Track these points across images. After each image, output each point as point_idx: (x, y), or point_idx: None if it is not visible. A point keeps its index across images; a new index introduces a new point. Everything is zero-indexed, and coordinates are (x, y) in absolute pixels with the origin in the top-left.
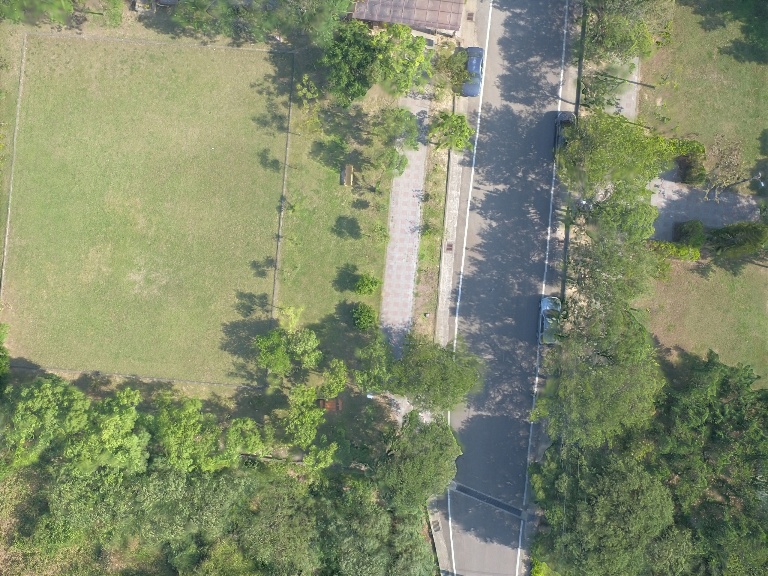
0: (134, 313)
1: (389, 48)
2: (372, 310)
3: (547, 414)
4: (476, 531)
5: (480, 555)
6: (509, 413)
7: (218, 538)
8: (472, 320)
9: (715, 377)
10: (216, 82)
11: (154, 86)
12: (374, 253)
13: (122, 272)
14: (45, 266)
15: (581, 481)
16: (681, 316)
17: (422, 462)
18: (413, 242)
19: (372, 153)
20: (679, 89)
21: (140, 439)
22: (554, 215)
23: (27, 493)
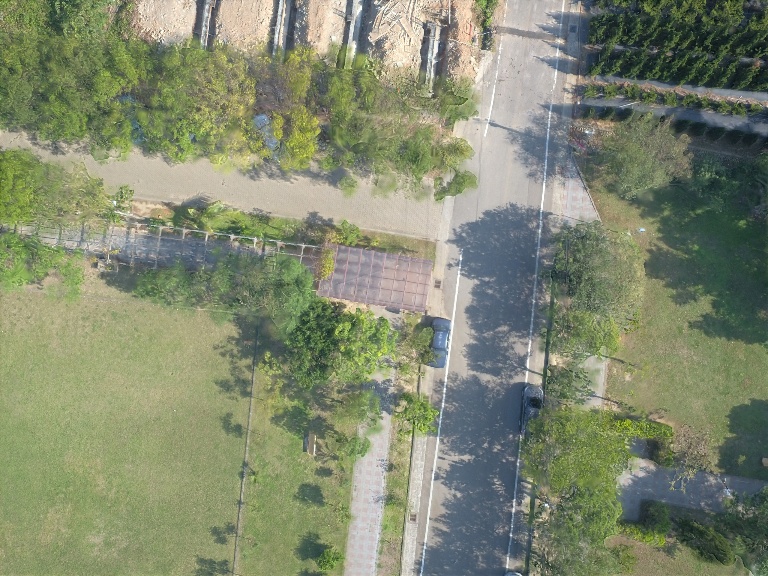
0: (93, 575)
1: (351, 341)
2: None
3: None
4: None
5: None
6: None
7: None
8: None
9: None
10: (179, 343)
11: (116, 345)
12: None
13: (81, 534)
14: (4, 525)
15: None
16: None
17: None
18: (376, 512)
19: (336, 421)
20: (648, 364)
21: None
22: (519, 487)
23: None
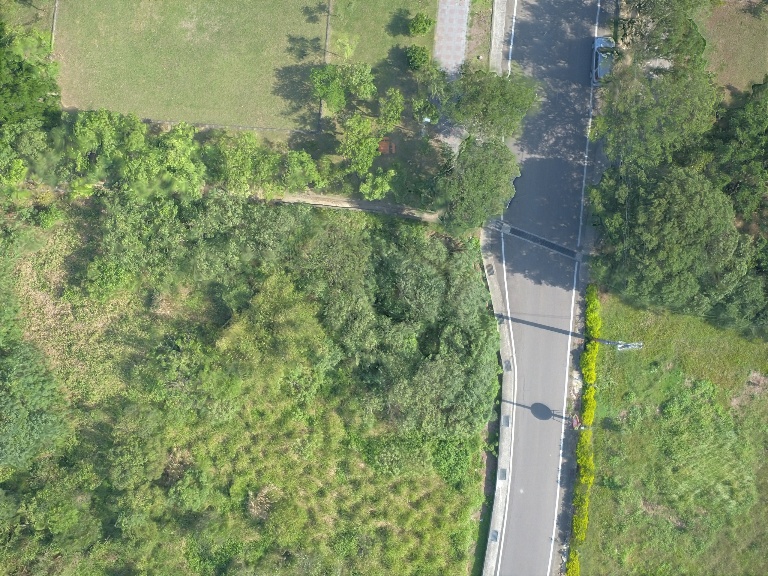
0: (186, 60)
1: None
2: (426, 50)
3: (606, 130)
4: (530, 274)
5: (535, 297)
6: (563, 155)
7: (274, 269)
8: (525, 64)
9: None
10: None
11: None
12: None
13: (174, 20)
14: (97, 16)
15: (642, 189)
16: (734, 55)
17: (483, 171)
18: None
19: None
20: None
21: (196, 167)
22: None
23: (77, 244)
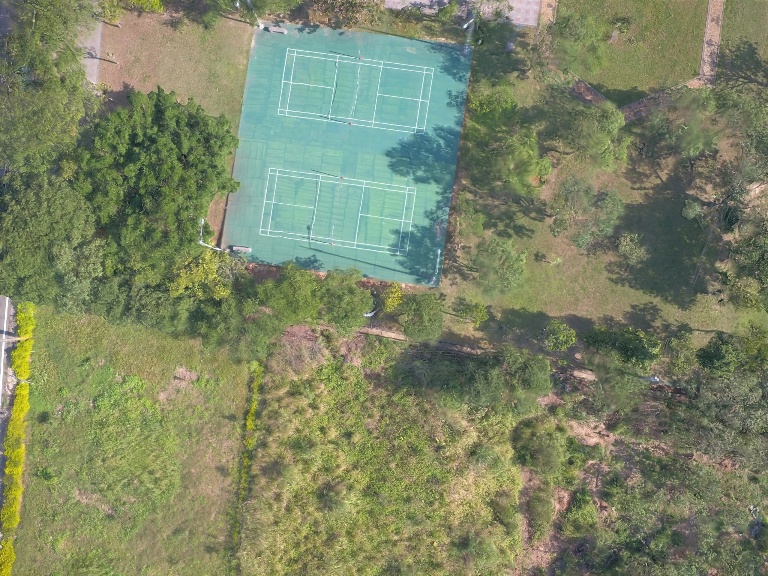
0: None
1: None
2: None
3: None
4: None
5: None
6: None
7: None
8: None
9: (149, 105)
10: None
11: None
12: None
13: None
14: None
15: (8, 196)
16: (156, 67)
17: None
18: None
19: None
20: None
21: None
22: None
23: None
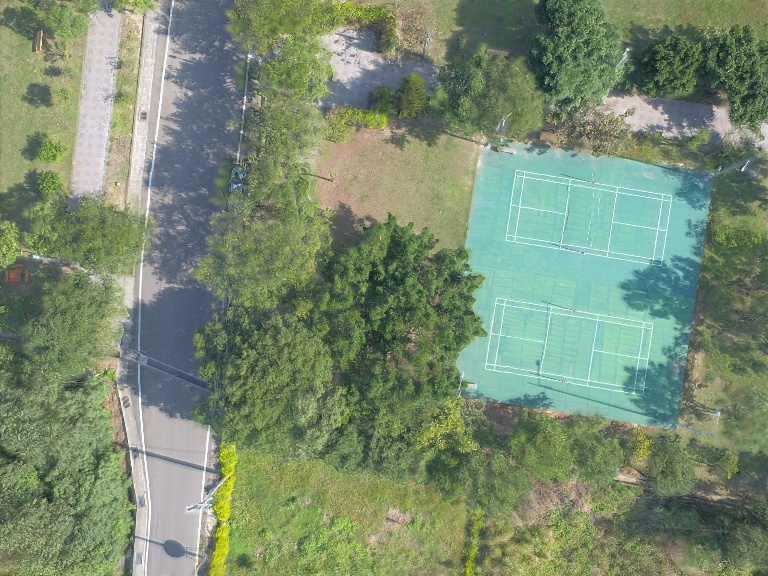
0: None
1: None
2: (57, 177)
3: (212, 272)
4: (166, 407)
5: (170, 431)
6: (201, 285)
7: None
8: (166, 190)
9: (386, 237)
10: None
11: None
12: (65, 121)
13: None
14: None
15: (238, 337)
16: (375, 186)
17: (73, 317)
18: (105, 110)
19: None
20: None
21: None
22: (250, 84)
23: None
